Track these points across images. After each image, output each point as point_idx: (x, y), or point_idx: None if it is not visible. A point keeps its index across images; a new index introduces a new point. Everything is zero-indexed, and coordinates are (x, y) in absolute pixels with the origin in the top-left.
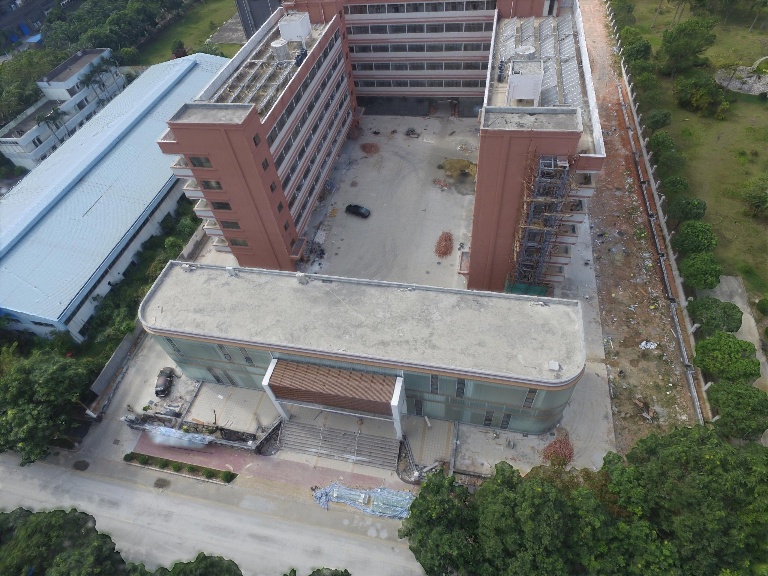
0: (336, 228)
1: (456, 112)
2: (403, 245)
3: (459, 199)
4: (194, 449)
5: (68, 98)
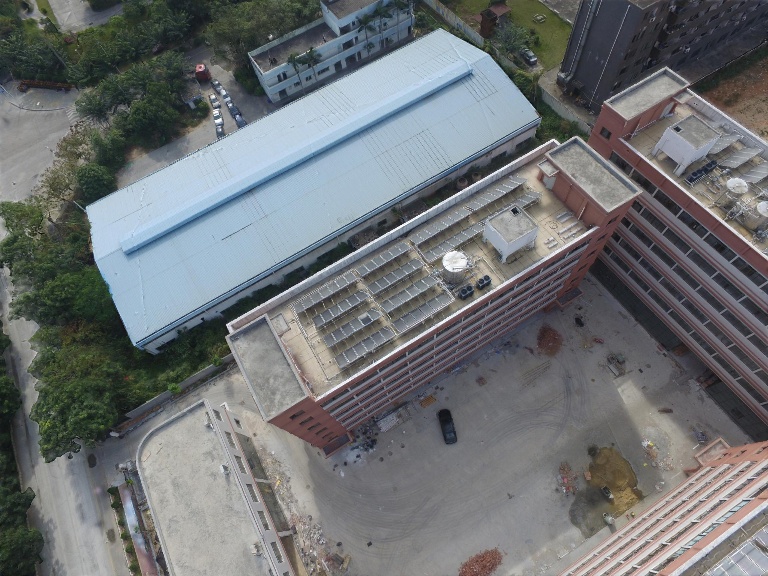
0: (411, 425)
1: (707, 383)
2: (444, 519)
3: (561, 522)
4: (144, 532)
5: (338, 33)
